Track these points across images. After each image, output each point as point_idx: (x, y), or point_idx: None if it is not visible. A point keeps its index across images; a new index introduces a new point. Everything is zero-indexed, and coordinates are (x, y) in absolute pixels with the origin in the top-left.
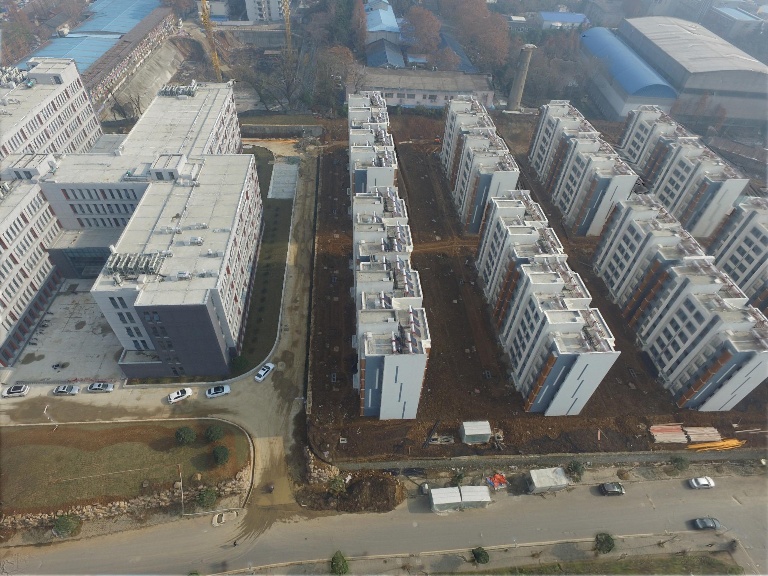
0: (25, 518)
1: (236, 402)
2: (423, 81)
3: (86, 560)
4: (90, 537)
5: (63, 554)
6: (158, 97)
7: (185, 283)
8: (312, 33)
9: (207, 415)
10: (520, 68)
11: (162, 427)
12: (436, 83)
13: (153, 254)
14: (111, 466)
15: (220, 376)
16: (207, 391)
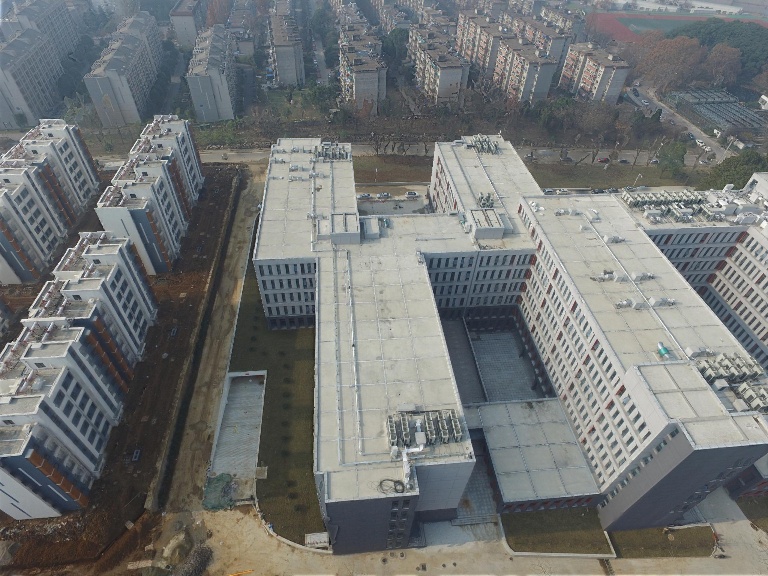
0: None
1: None
2: None
3: None
4: None
5: None
6: (458, 410)
7: None
8: None
9: None
10: None
11: None
12: None
13: None
14: None
15: None
16: None
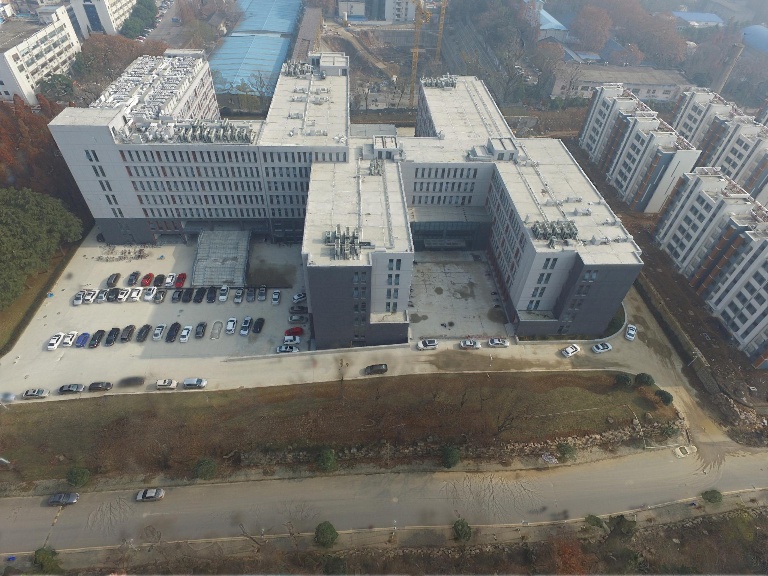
0: (522, 446)
1: (622, 357)
2: (623, 76)
3: (588, 482)
4: (578, 464)
5: (565, 477)
6: (425, 88)
7: (607, 247)
8: (499, 31)
9: (604, 367)
10: (729, 63)
11: (579, 376)
12: (636, 77)
13: (568, 222)
14: (569, 405)
15: (595, 335)
16: (595, 347)
